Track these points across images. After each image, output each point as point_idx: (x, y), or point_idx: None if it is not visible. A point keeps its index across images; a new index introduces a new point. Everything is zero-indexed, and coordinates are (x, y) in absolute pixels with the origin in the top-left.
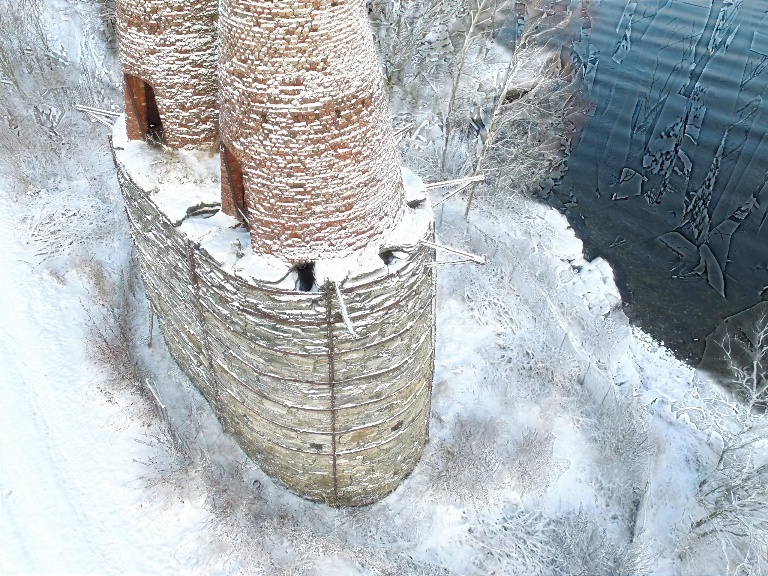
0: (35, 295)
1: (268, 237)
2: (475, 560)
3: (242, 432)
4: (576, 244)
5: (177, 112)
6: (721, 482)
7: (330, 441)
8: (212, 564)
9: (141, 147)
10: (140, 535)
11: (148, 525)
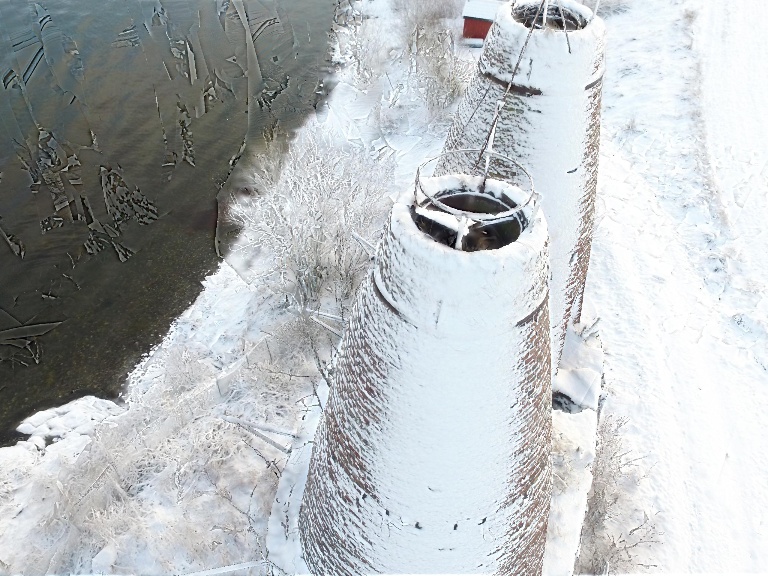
0: None
1: None
2: None
3: None
4: (0, 454)
5: None
6: (305, 284)
7: None
8: (629, 497)
9: None
10: (662, 575)
11: (652, 574)
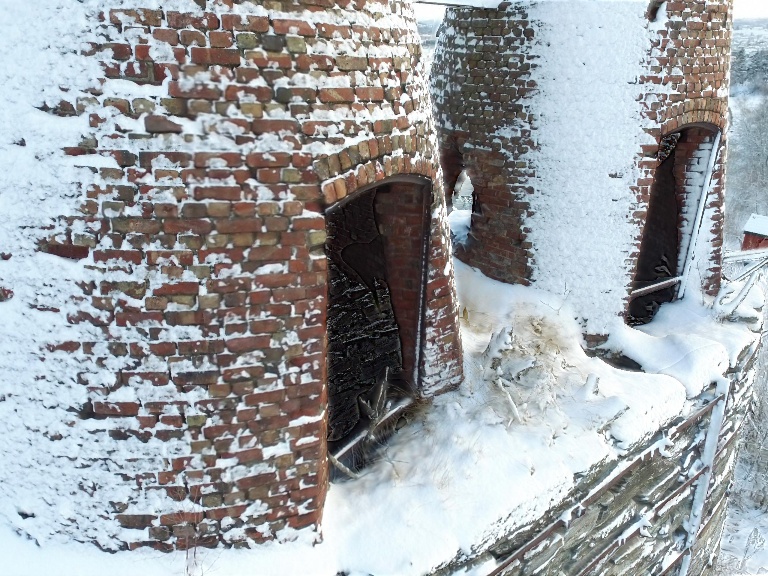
0: None
1: None
2: None
3: None
4: None
5: None
6: None
7: None
8: None
9: (372, 488)
10: None
11: None
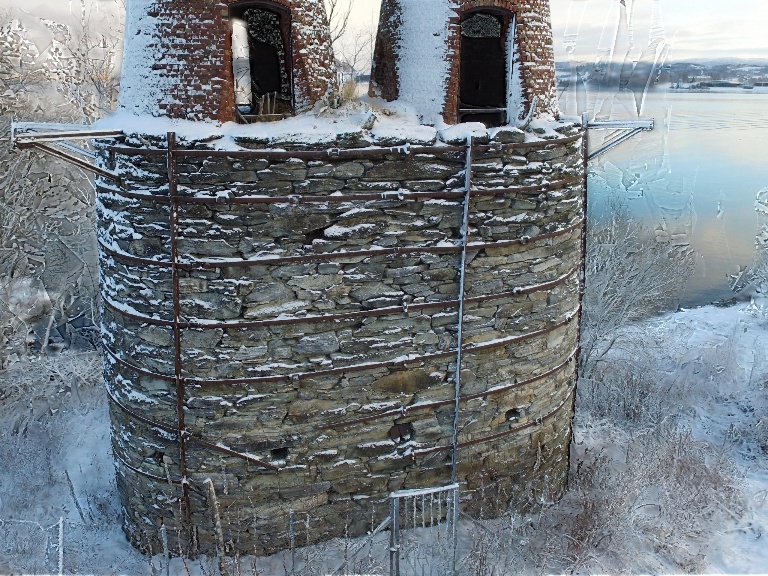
0: None
1: (542, 91)
2: (621, 449)
3: (496, 467)
4: None
5: (316, 44)
6: None
7: (575, 362)
8: None
9: None
10: None
11: None
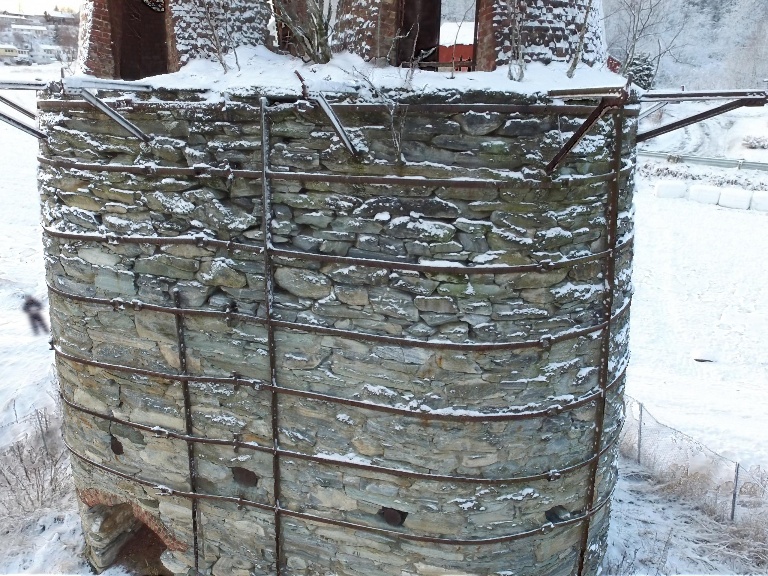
0: (767, 451)
1: None
2: None
3: None
4: None
5: None
6: None
7: None
8: None
9: None
10: None
11: None
